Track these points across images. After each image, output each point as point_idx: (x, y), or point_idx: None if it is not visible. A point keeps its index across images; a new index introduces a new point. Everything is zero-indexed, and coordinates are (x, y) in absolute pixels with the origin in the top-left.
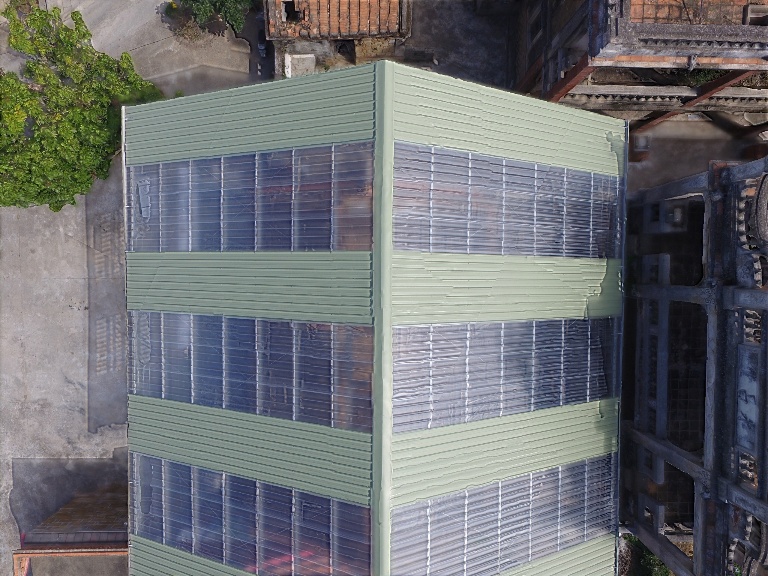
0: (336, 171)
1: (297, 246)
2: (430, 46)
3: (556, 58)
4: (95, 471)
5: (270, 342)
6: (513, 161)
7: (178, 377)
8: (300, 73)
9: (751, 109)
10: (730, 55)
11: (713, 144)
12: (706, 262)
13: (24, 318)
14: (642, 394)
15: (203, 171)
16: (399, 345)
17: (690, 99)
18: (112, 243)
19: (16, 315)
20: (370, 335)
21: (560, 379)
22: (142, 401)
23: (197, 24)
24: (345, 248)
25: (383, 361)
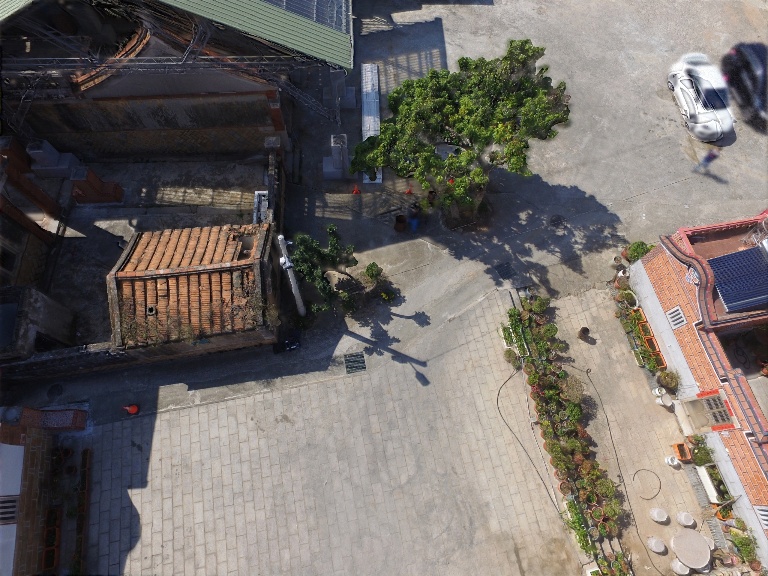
0: None
1: None
2: None
3: None
4: None
5: None
6: None
7: None
8: None
9: None
10: None
11: None
12: None
13: None
14: None
15: None
16: None
17: None
18: None
19: None
20: None
21: None
22: None
23: None
24: None
25: None
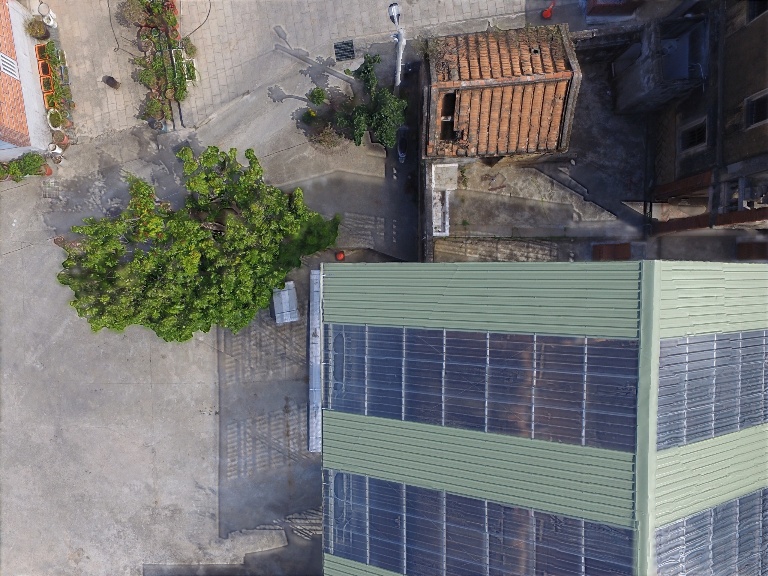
0: (589, 364)
1: (538, 433)
2: None
3: (733, 183)
4: None
5: (504, 527)
6: (748, 333)
7: (387, 545)
8: (444, 182)
9: None
10: None
11: None
12: None
13: (155, 423)
14: None
15: (420, 341)
16: (660, 547)
17: None
18: (243, 347)
19: (147, 420)
20: (632, 539)
21: None
22: (342, 562)
23: (333, 130)
24: (601, 445)
25: (649, 568)
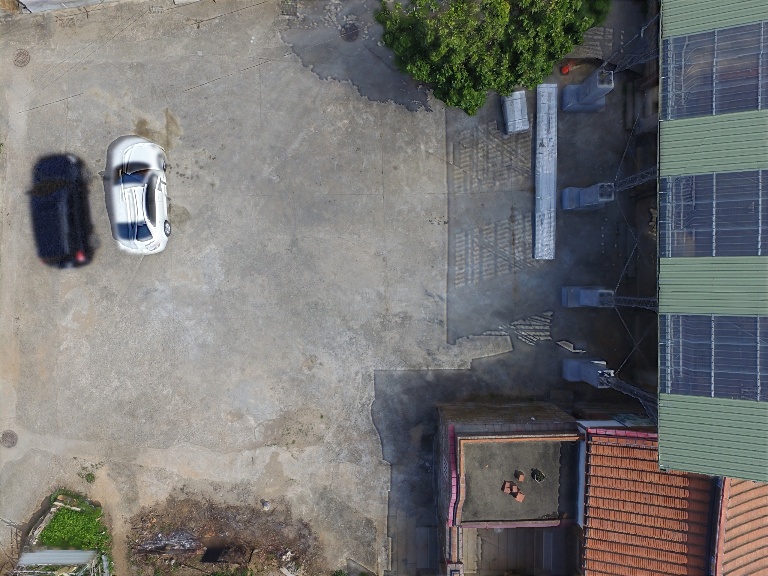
0: None
1: None
2: None
3: None
4: (454, 382)
5: None
6: None
7: (738, 233)
8: None
9: None
10: None
11: None
12: None
13: (386, 233)
14: None
15: None
16: None
17: None
18: (471, 159)
19: (378, 230)
20: None
21: None
22: (681, 262)
23: None
24: None
25: None
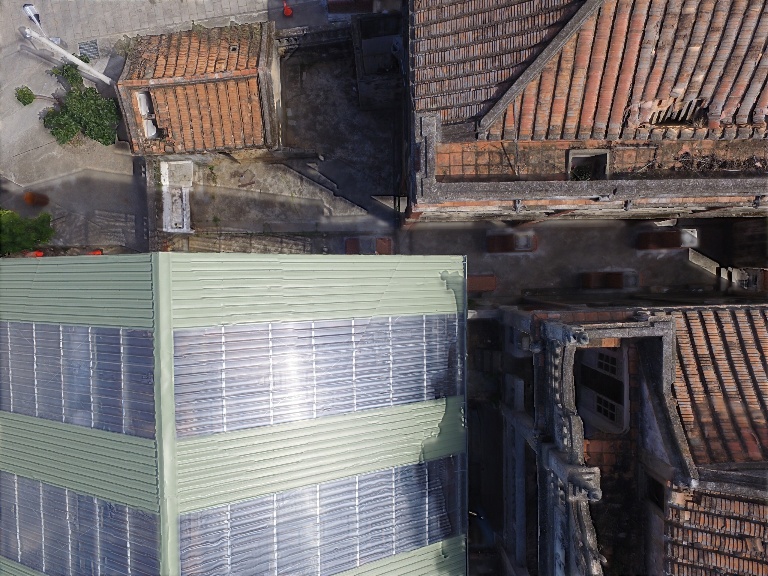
0: (125, 354)
1: (97, 422)
2: (315, 142)
3: None
4: None
5: (79, 514)
6: (324, 322)
7: (7, 534)
8: (178, 179)
9: (620, 216)
10: (555, 198)
11: (607, 231)
12: None
13: None
14: (508, 514)
15: (19, 334)
16: (189, 531)
17: (551, 213)
18: None
19: None
20: (158, 523)
21: (392, 528)
22: None
23: None
24: (135, 432)
25: (169, 551)
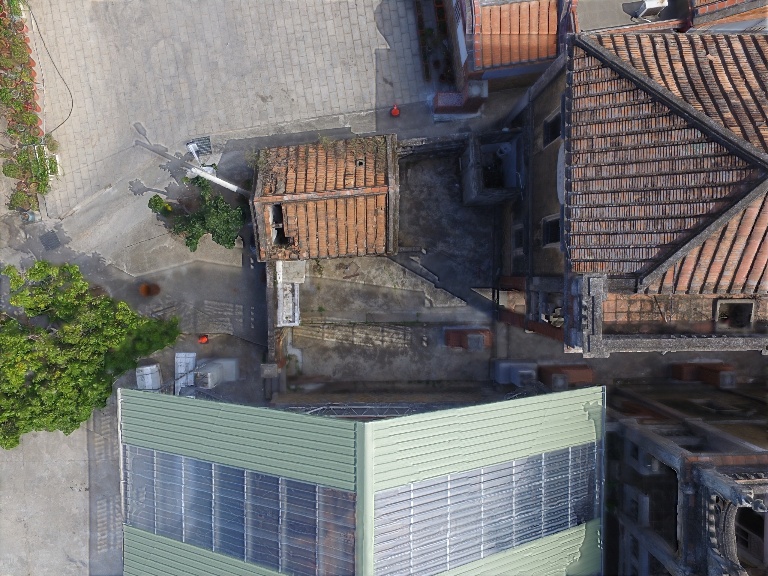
0: (320, 510)
1: (284, 568)
2: (418, 236)
3: (537, 293)
4: None
5: None
6: (491, 467)
7: None
8: (291, 276)
9: None
10: None
11: None
12: (680, 541)
13: (27, 499)
14: None
15: (195, 471)
16: None
17: None
18: (111, 426)
19: (19, 497)
20: None
21: None
22: None
23: None
24: None
25: None
